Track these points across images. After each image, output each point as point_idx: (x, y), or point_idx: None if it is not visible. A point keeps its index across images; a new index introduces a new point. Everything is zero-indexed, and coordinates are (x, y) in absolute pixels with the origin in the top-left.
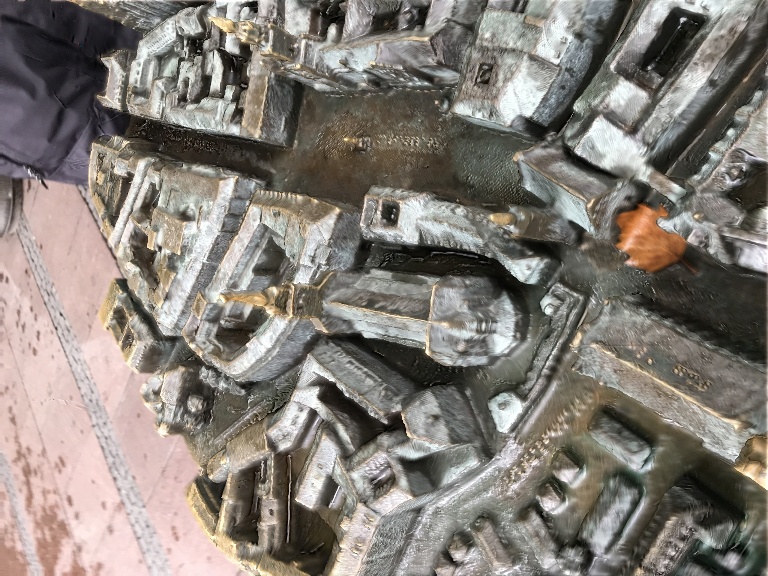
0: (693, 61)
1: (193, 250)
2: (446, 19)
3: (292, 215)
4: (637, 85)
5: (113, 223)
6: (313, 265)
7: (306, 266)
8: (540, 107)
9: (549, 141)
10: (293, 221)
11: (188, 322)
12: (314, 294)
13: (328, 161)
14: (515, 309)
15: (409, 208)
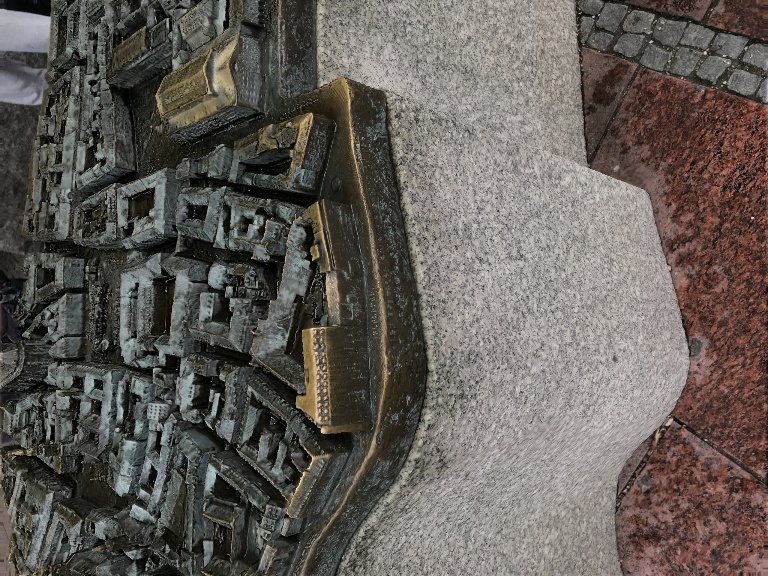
0: (154, 487)
1: (38, 529)
2: (106, 446)
3: (66, 521)
4: (146, 491)
5: (8, 504)
6: (76, 545)
7: (73, 546)
8: (131, 489)
9: (130, 506)
10: (67, 524)
11: (36, 569)
12: (64, 567)
13: (94, 482)
14: (137, 568)
15: (99, 525)
